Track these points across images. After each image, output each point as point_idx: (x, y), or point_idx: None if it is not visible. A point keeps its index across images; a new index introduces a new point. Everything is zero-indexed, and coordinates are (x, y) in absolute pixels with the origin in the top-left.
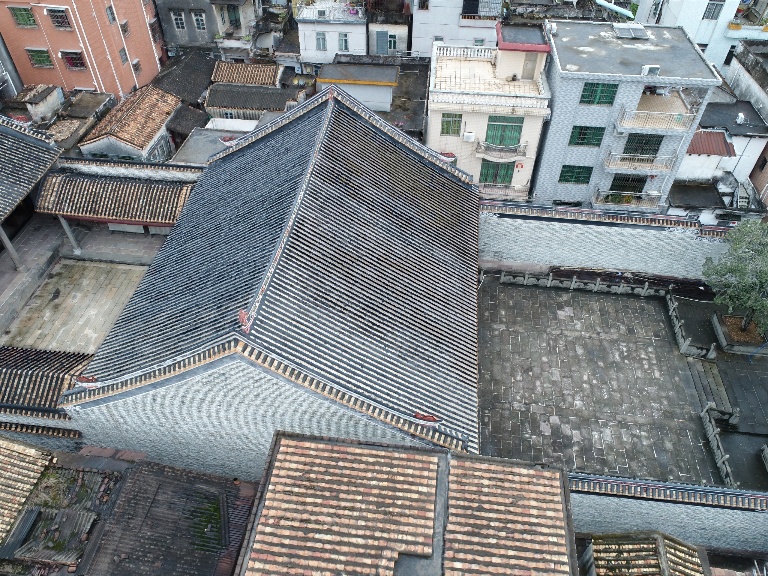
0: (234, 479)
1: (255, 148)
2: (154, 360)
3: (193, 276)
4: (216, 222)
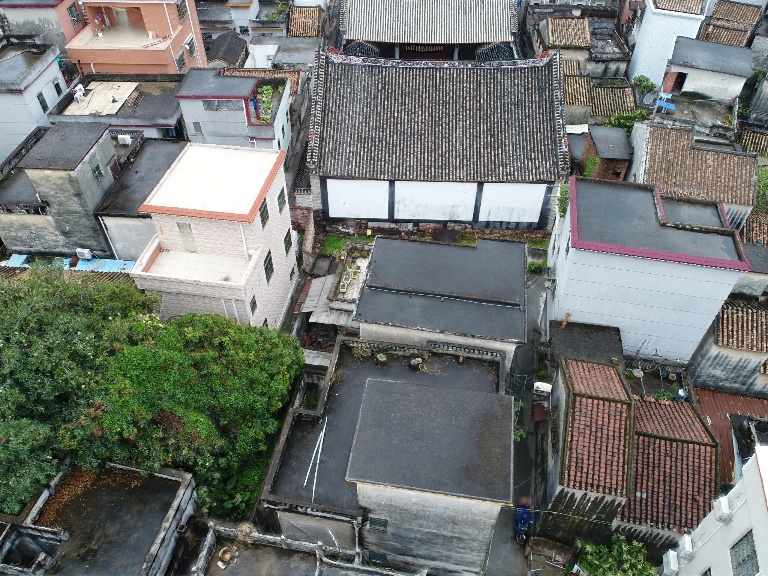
0: (528, 4)
1: (350, 3)
2: (501, 2)
3: (452, 6)
4: (412, 8)
